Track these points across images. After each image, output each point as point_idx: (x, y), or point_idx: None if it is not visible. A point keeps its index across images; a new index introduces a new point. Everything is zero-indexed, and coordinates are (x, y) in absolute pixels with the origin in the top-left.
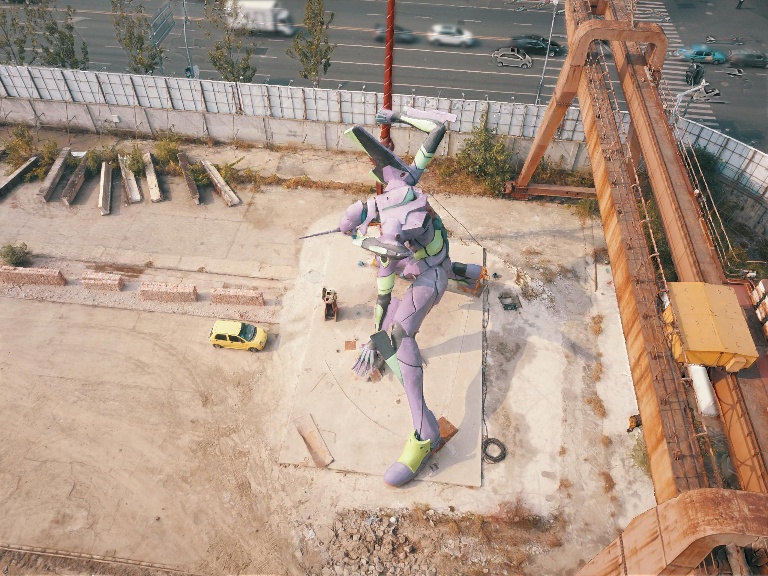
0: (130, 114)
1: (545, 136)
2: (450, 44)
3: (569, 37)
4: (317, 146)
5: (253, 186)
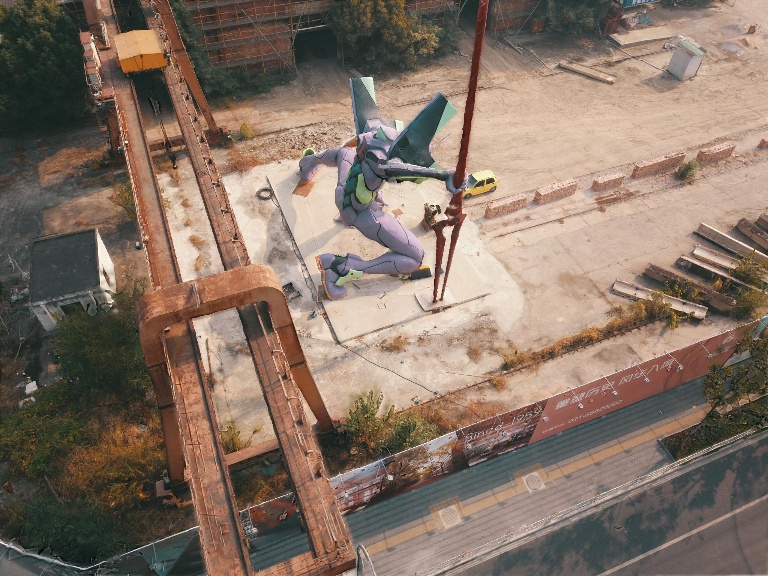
0: None
1: None
2: None
3: None
4: None
5: None
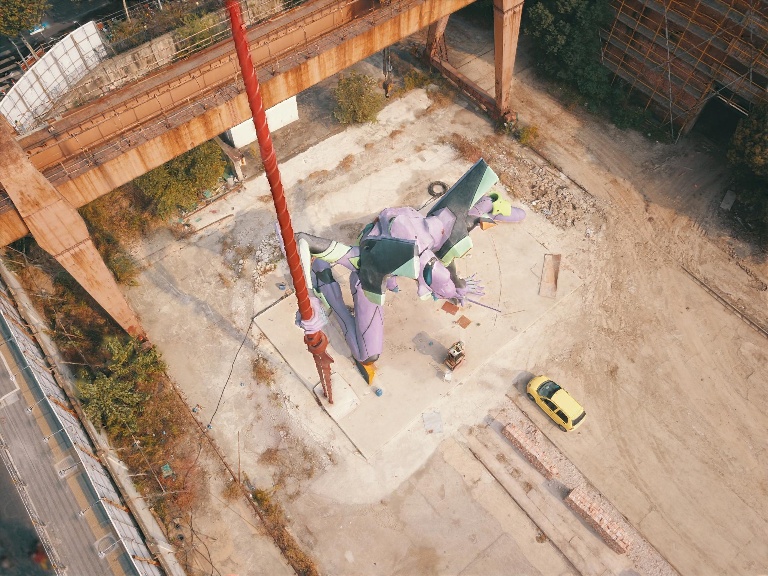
0: None
1: None
2: None
3: None
4: None
5: None
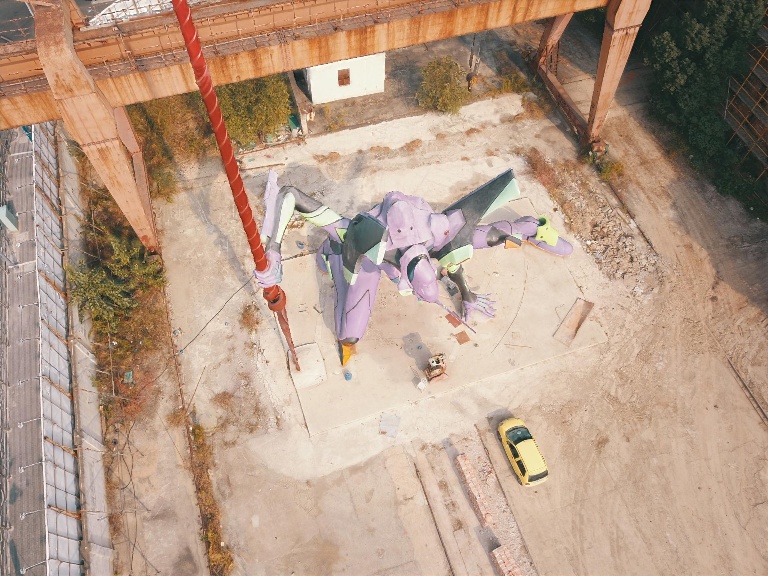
0: None
1: None
2: None
3: None
4: (110, 569)
5: None
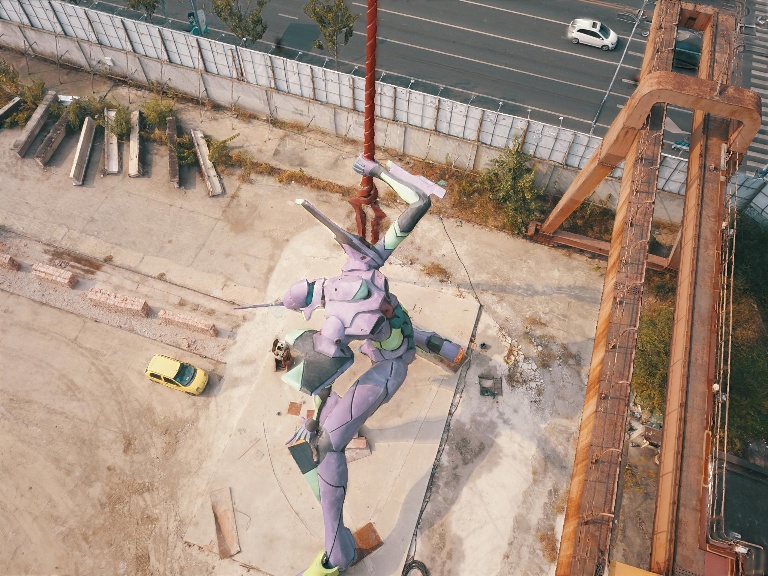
0: (124, 59)
1: (580, 191)
2: (522, 0)
3: (644, 63)
4: (326, 129)
5: (241, 174)
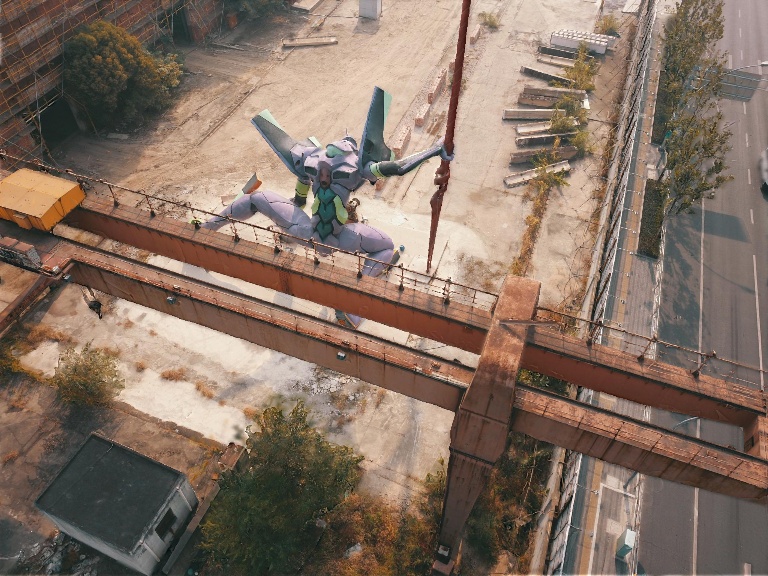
0: None
1: None
2: None
3: None
4: None
5: (527, 192)
